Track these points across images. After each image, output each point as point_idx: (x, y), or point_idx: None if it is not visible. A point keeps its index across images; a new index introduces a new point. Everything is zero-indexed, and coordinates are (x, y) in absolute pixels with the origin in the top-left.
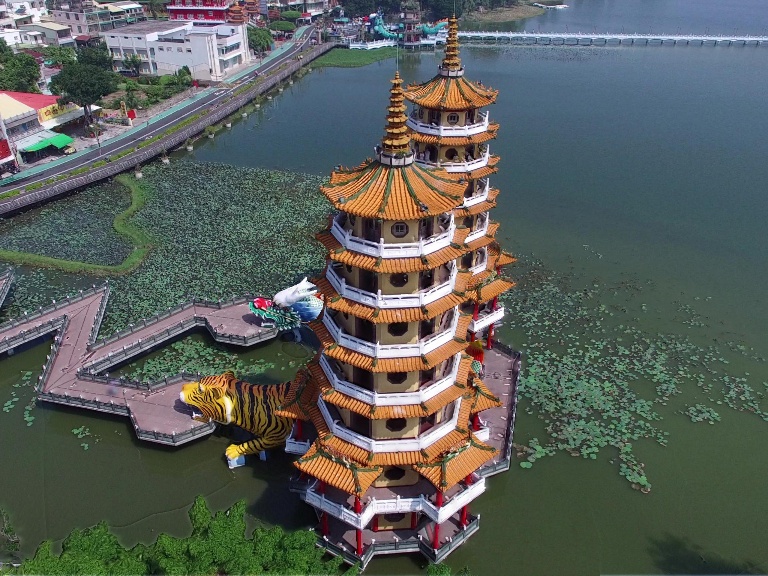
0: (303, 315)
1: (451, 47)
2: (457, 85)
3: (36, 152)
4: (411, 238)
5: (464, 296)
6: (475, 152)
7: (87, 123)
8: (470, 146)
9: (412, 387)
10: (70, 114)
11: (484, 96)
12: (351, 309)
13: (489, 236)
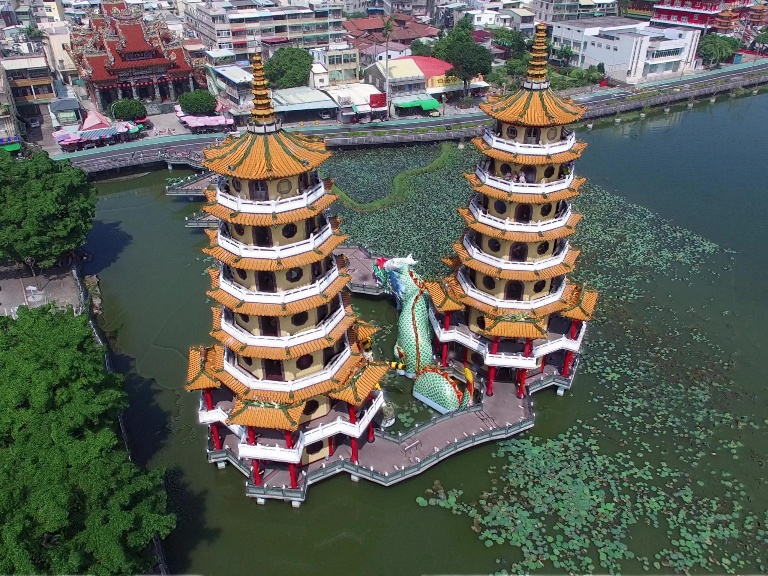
0: (394, 284)
1: (534, 56)
2: (527, 98)
3: (409, 109)
4: (244, 195)
5: (279, 265)
6: (538, 176)
7: (463, 95)
8: (527, 167)
9: (254, 331)
10: (460, 86)
11: (548, 115)
12: (213, 239)
13: (537, 273)
